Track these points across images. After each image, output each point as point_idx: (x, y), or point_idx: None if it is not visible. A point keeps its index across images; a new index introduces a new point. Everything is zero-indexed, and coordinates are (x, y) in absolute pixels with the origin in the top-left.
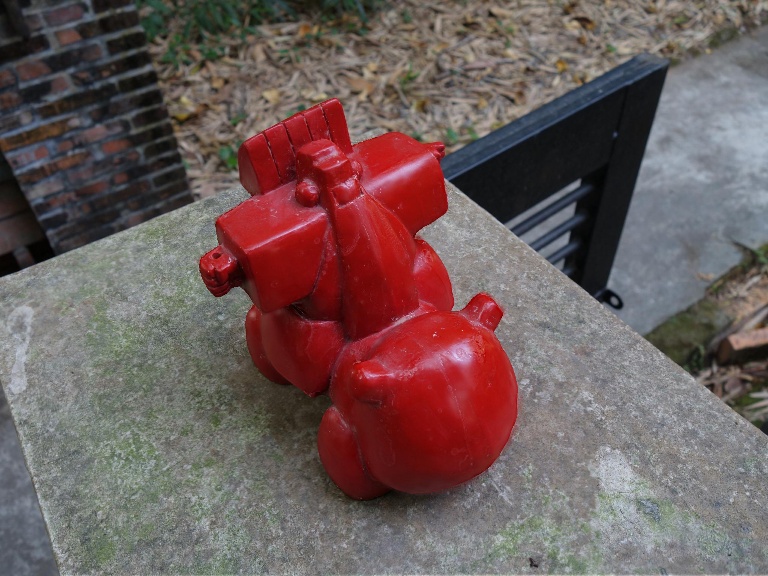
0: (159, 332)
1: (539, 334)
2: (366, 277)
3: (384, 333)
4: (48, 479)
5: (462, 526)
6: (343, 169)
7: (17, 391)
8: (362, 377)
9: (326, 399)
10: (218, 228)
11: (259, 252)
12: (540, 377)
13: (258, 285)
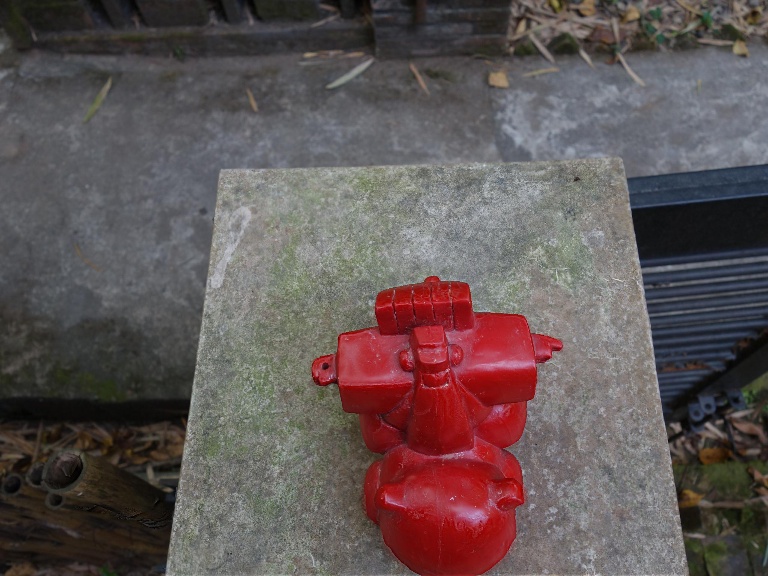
0: (322, 290)
1: (597, 475)
2: (425, 432)
3: (430, 459)
4: (204, 372)
5: None
6: (437, 366)
7: (214, 286)
8: (383, 499)
9: None
10: None
11: (349, 389)
12: (568, 514)
13: (343, 402)
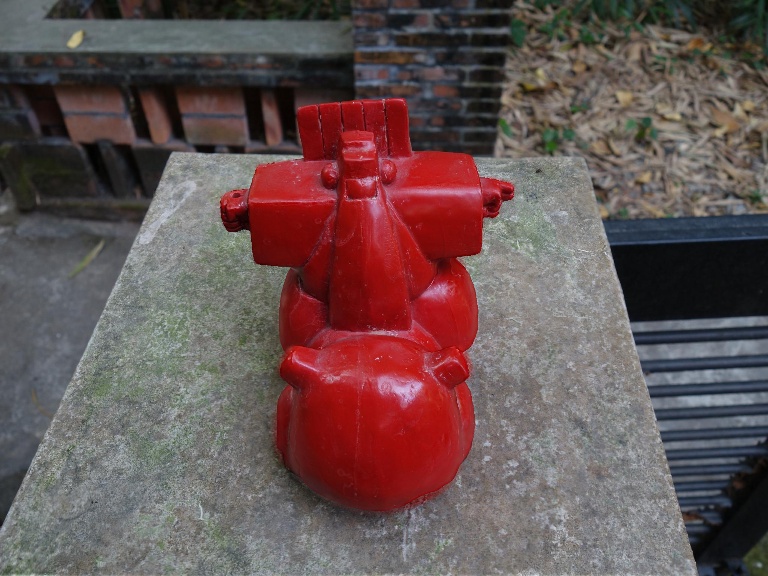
0: None
1: (567, 428)
2: (348, 275)
3: (355, 335)
4: (111, 316)
5: (349, 548)
6: (363, 166)
7: (142, 242)
8: (291, 358)
9: None
10: None
11: (260, 207)
12: (531, 468)
13: (253, 236)
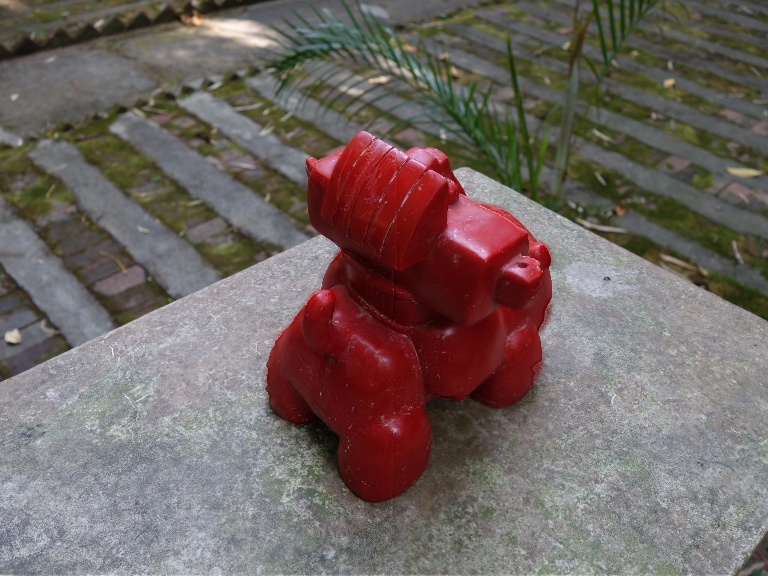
0: None
1: None
2: None
3: None
4: None
5: None
6: None
7: None
8: (542, 249)
9: (437, 417)
10: (492, 263)
11: None
12: None
13: None
